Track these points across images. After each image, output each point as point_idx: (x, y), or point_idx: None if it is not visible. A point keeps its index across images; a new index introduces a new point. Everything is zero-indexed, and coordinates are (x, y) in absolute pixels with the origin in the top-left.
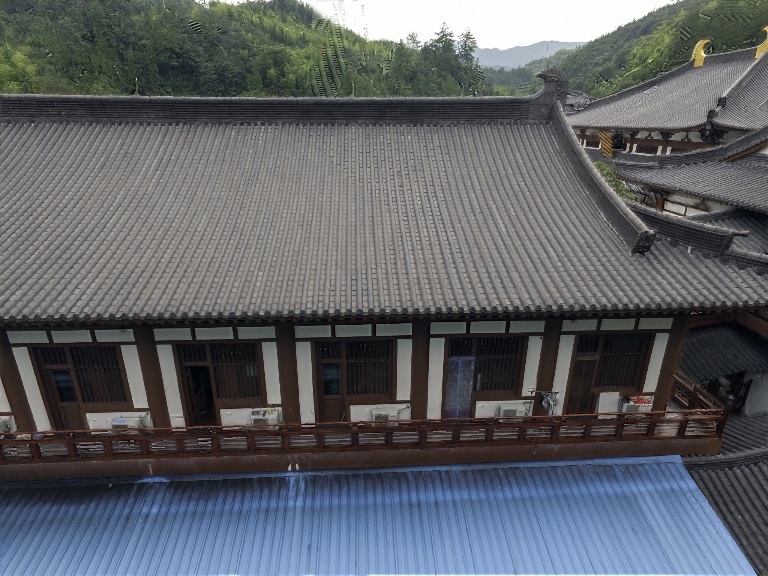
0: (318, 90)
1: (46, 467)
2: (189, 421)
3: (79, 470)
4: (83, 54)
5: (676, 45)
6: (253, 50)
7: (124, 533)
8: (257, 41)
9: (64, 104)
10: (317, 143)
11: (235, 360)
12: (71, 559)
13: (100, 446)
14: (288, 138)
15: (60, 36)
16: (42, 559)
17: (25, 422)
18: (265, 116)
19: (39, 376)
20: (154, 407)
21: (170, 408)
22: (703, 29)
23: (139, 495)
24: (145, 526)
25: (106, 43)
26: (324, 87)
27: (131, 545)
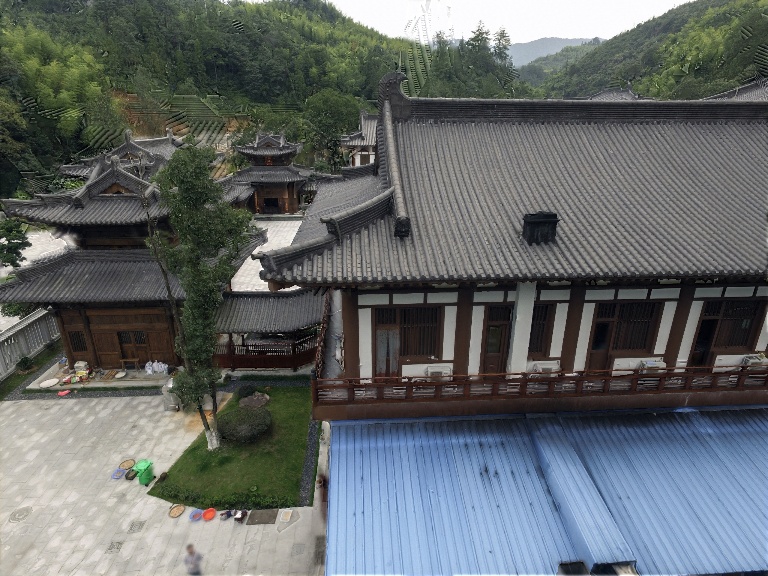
0: (402, 89)
1: (611, 399)
2: (689, 365)
3: (634, 401)
4: (137, 54)
5: (737, 44)
6: (294, 49)
7: (706, 446)
8: (298, 40)
9: (503, 107)
10: (714, 139)
11: (739, 314)
12: (687, 463)
13: (655, 382)
14: (688, 135)
15: (115, 36)
16: (665, 464)
17: (569, 365)
18: (662, 116)
19: (594, 327)
20: (670, 353)
21: (680, 354)
22: (765, 28)
23: (686, 421)
24: (716, 442)
25: (158, 43)
26: (408, 86)
27: (720, 454)
